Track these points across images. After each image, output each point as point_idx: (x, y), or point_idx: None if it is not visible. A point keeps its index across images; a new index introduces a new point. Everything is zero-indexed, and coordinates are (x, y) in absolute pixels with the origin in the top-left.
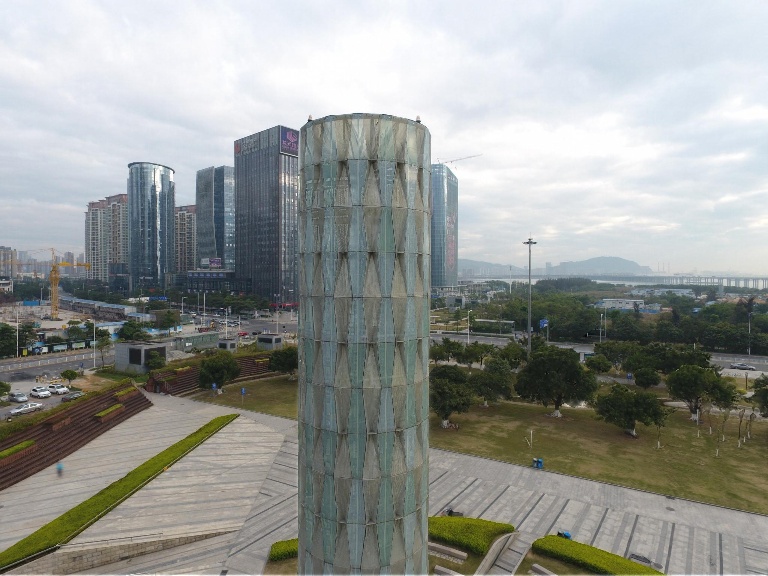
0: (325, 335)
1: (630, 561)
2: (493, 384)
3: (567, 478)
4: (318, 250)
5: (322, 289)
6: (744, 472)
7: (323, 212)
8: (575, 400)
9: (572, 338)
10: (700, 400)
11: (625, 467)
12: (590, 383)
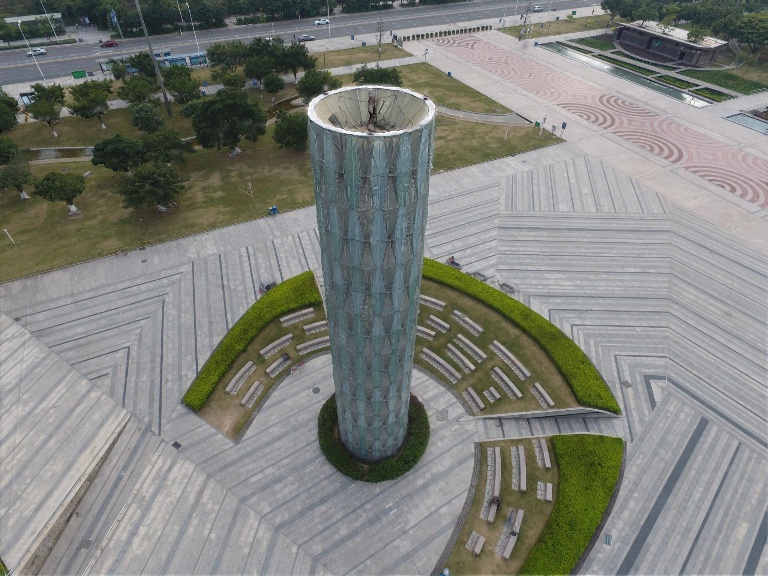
0: (394, 287)
1: None
2: (174, 144)
3: (298, 212)
4: (387, 238)
5: (393, 262)
6: None
7: (396, 212)
8: (255, 136)
9: (167, 39)
10: None
11: None
12: (264, 118)
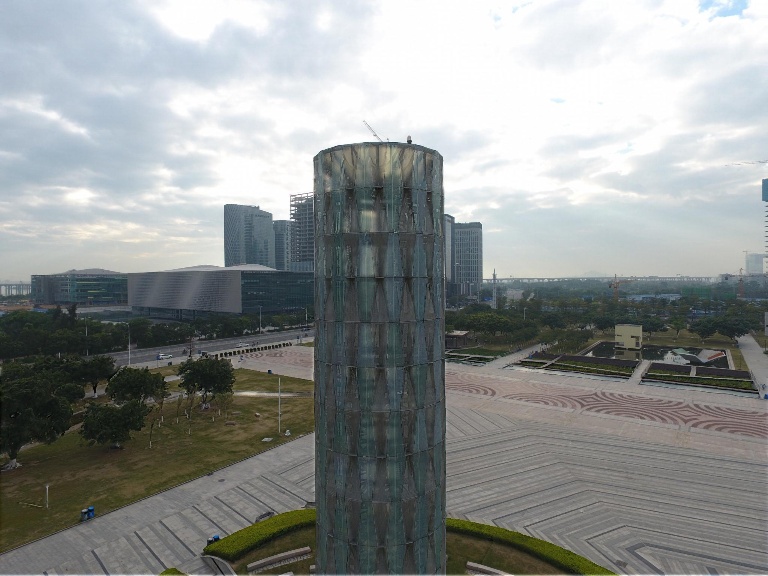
0: None
1: (269, 519)
2: None
3: (128, 508)
4: None
5: (432, 312)
6: (216, 436)
7: (433, 239)
8: (53, 435)
9: None
10: (143, 397)
11: (153, 473)
12: (71, 409)
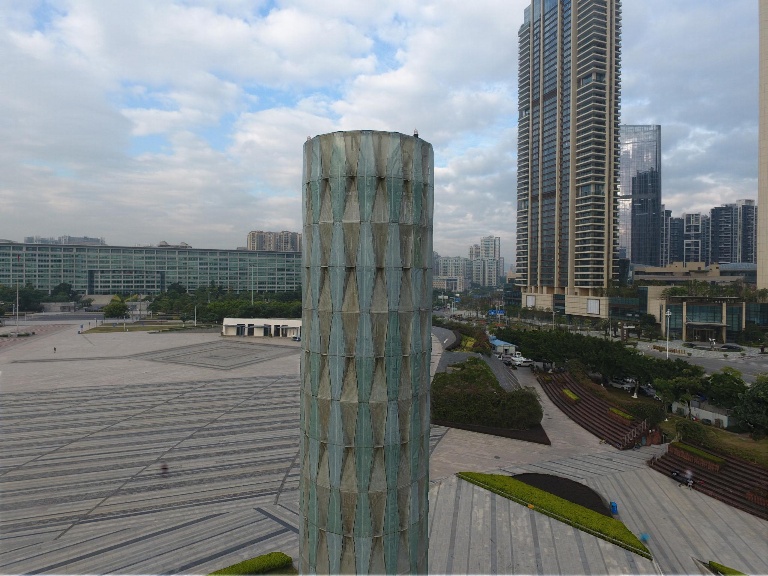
0: None
1: None
2: None
3: None
4: None
5: None
6: None
7: None
8: None
9: None
10: None
11: None
12: None
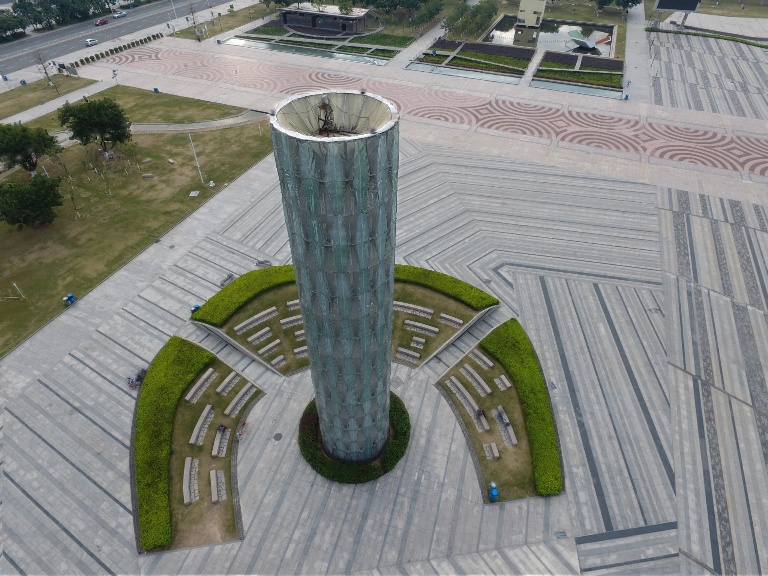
0: None
1: (232, 284)
2: None
3: (102, 287)
4: None
5: (389, 249)
6: (141, 194)
7: None
8: None
9: None
10: (34, 156)
11: (102, 247)
12: None
